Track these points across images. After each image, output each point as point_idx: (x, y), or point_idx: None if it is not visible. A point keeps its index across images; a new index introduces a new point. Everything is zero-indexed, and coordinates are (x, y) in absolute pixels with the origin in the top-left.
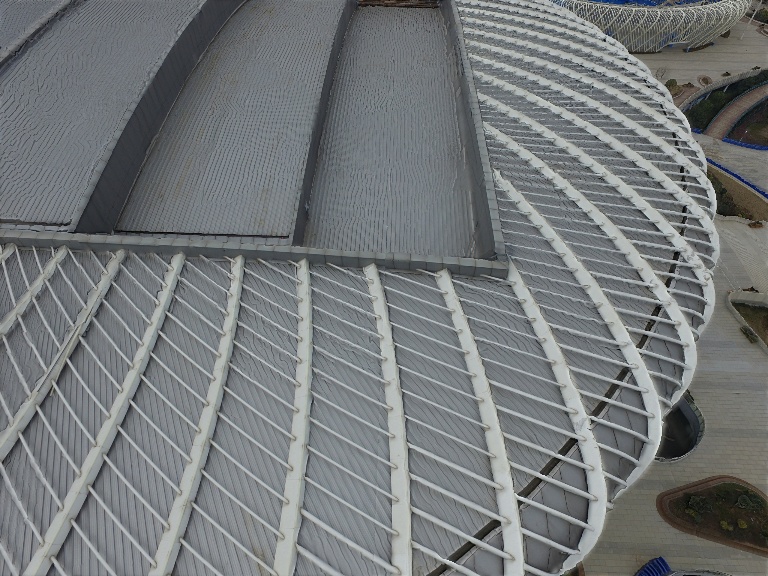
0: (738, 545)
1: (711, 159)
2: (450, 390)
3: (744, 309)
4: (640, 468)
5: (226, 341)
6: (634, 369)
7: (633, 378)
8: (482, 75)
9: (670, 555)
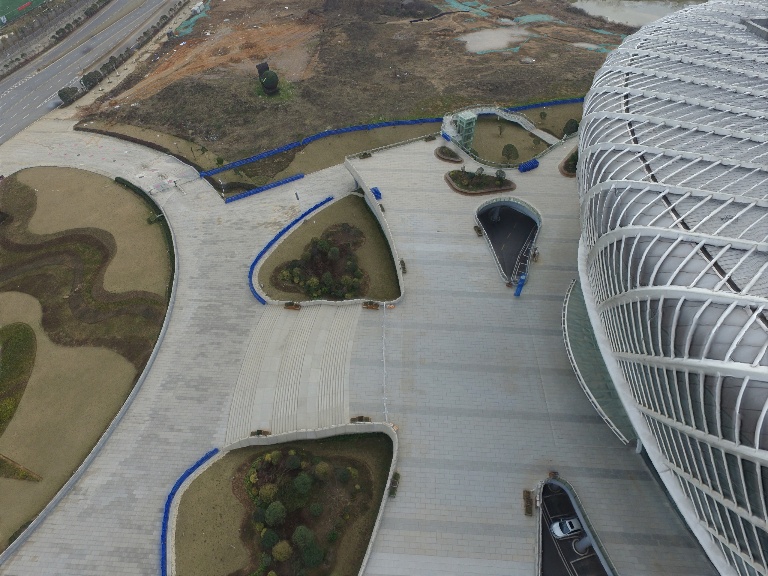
0: None
1: None
2: None
3: None
4: None
5: None
6: None
7: None
8: None
9: (515, 173)
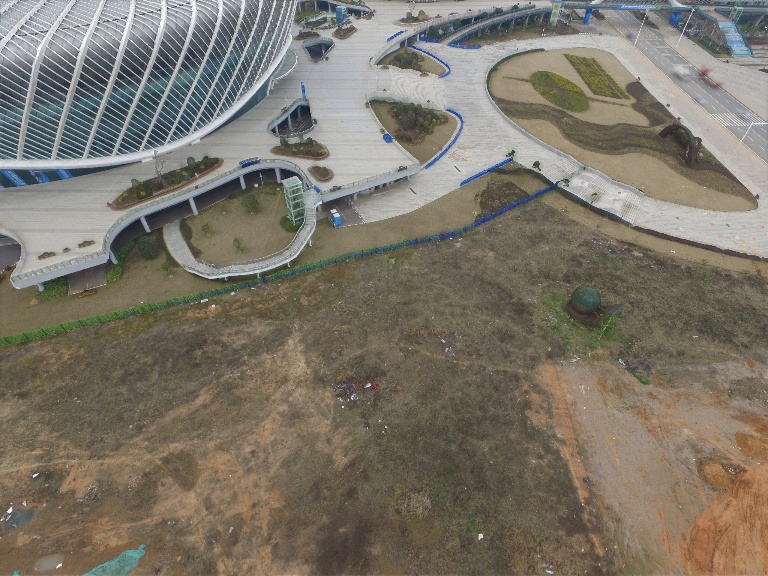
0: (298, 157)
1: (432, 53)
2: (90, 4)
3: (384, 103)
4: (158, 36)
5: None
6: None
7: None
8: None
9: None
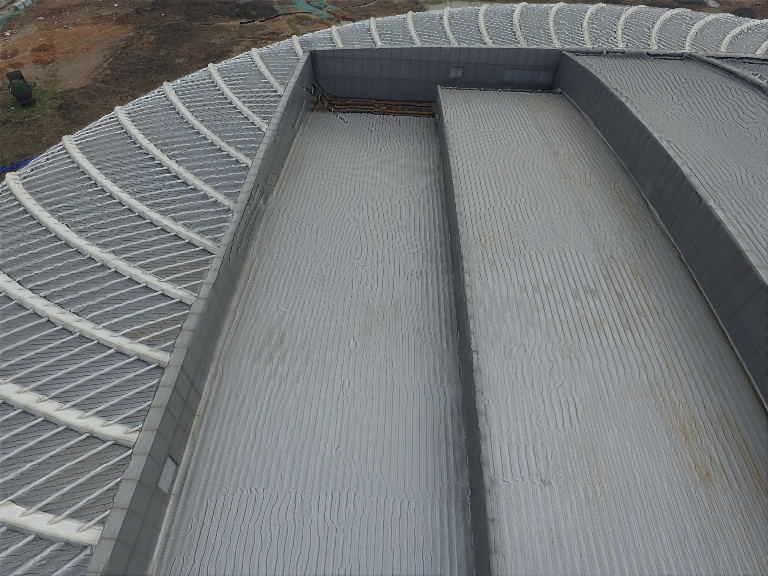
0: None
1: None
2: None
3: None
4: None
5: (450, 33)
6: None
7: None
8: (224, 199)
9: None
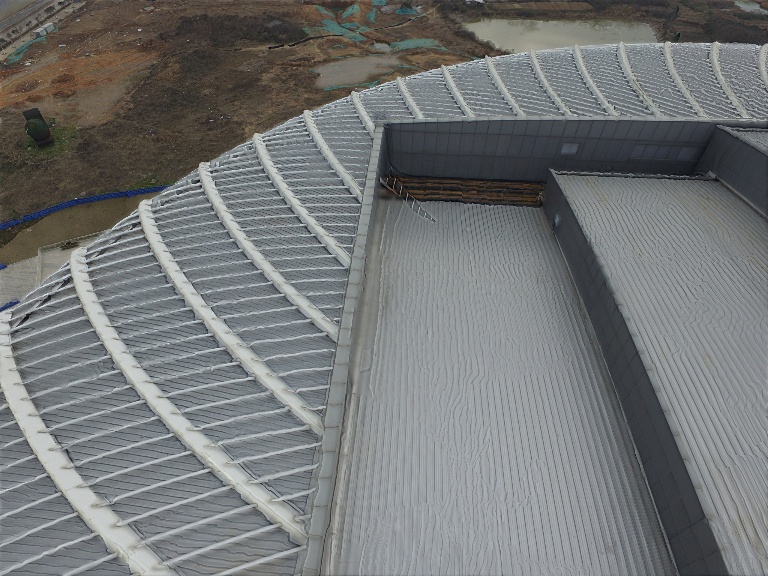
0: None
1: None
2: None
3: None
4: None
5: None
6: None
7: None
8: (302, 409)
9: None
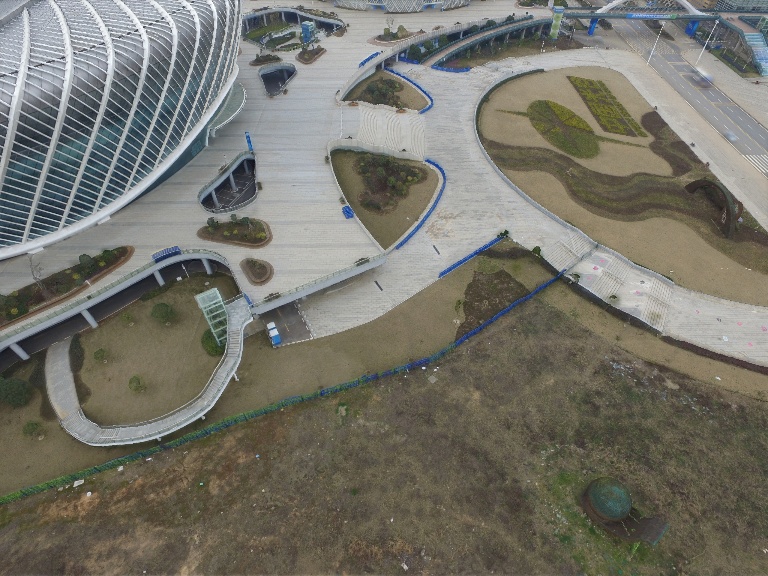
0: (231, 243)
1: (412, 79)
2: None
3: (350, 153)
4: (13, 109)
5: None
6: (19, 71)
7: (17, 74)
8: None
9: (188, 248)
